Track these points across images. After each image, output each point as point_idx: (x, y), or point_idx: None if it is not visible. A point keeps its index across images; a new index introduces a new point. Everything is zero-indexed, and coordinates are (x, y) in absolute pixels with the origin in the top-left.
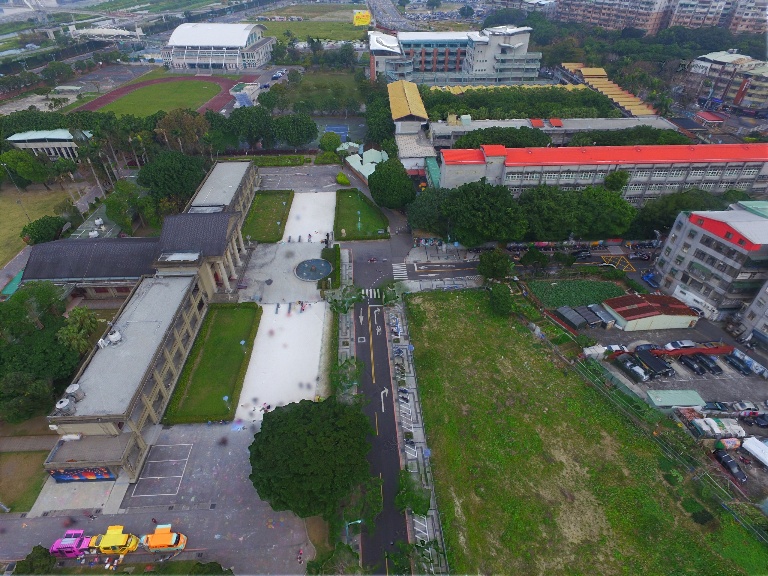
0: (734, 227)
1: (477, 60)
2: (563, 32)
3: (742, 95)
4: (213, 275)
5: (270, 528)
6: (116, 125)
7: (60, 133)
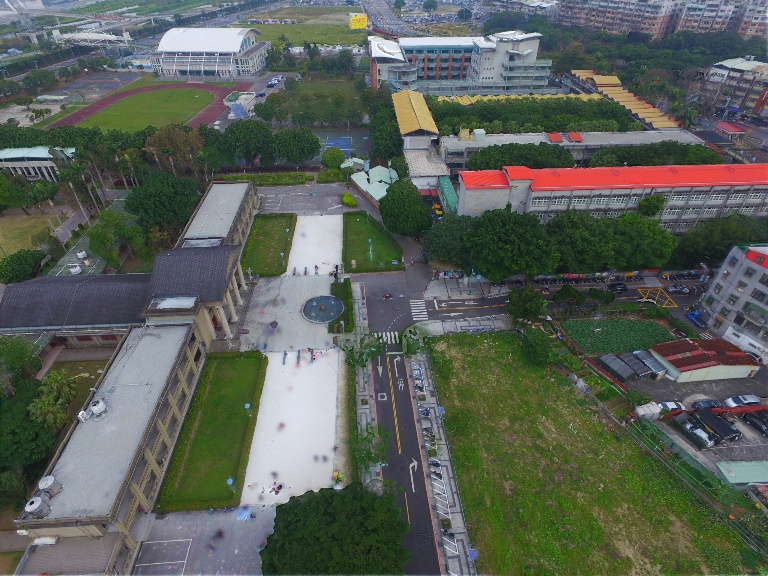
0: None
1: (484, 67)
2: (568, 36)
3: (762, 104)
4: (211, 319)
5: None
6: (101, 142)
7: (40, 151)
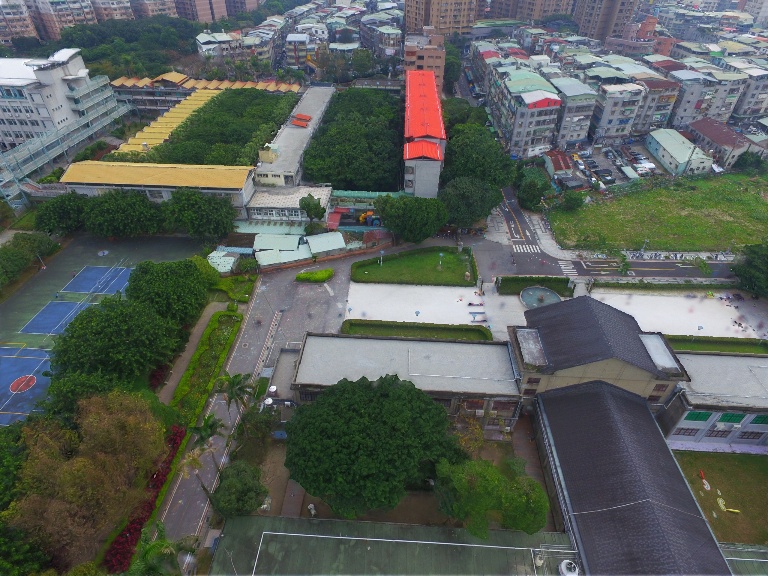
0: (551, 98)
1: (52, 109)
2: None
3: None
4: None
5: None
6: None
7: None
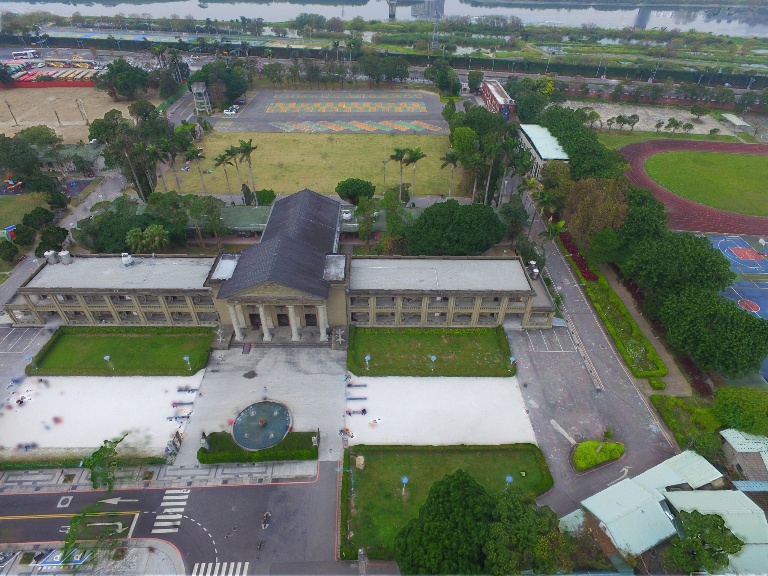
0: None
1: None
2: None
3: None
4: (248, 313)
5: None
6: None
7: (547, 141)
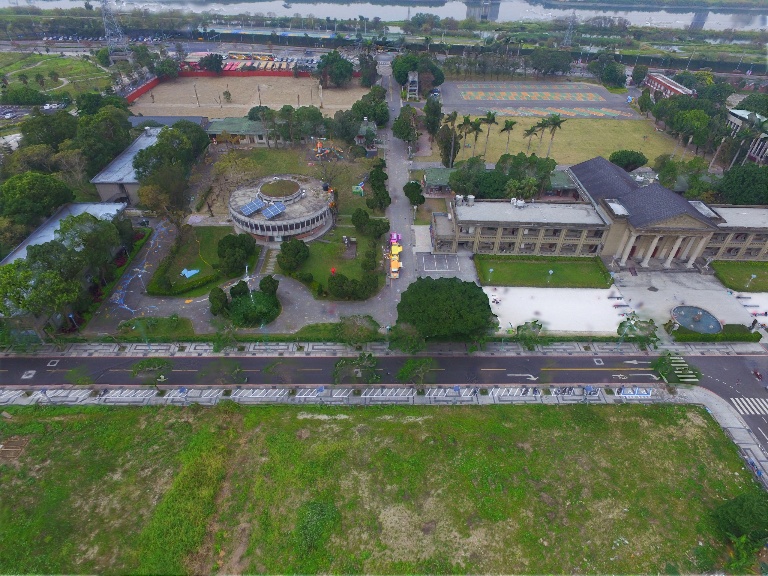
0: None
1: None
2: None
3: None
4: None
5: None
6: None
7: None
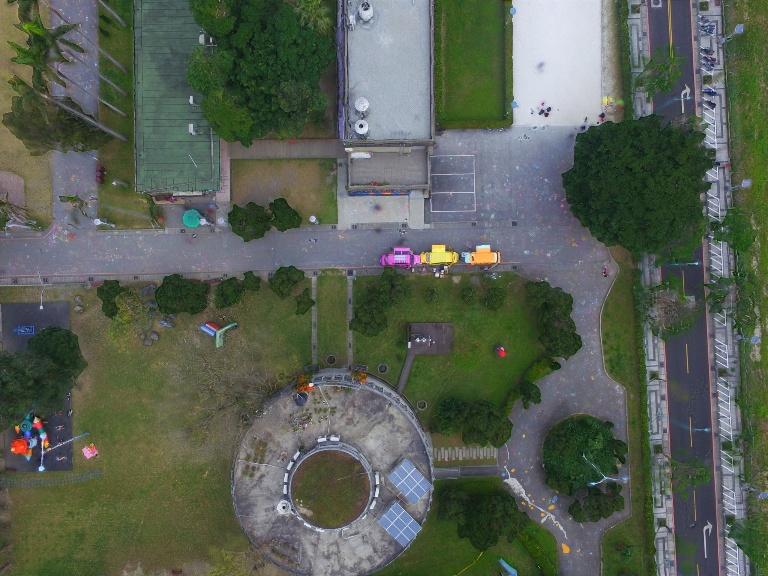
0: None
1: None
2: None
3: None
4: None
5: (574, 246)
6: None
7: None
